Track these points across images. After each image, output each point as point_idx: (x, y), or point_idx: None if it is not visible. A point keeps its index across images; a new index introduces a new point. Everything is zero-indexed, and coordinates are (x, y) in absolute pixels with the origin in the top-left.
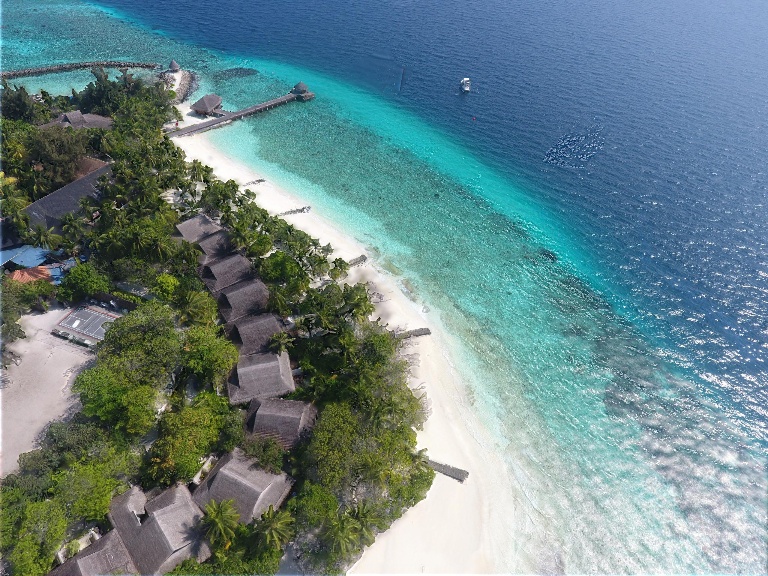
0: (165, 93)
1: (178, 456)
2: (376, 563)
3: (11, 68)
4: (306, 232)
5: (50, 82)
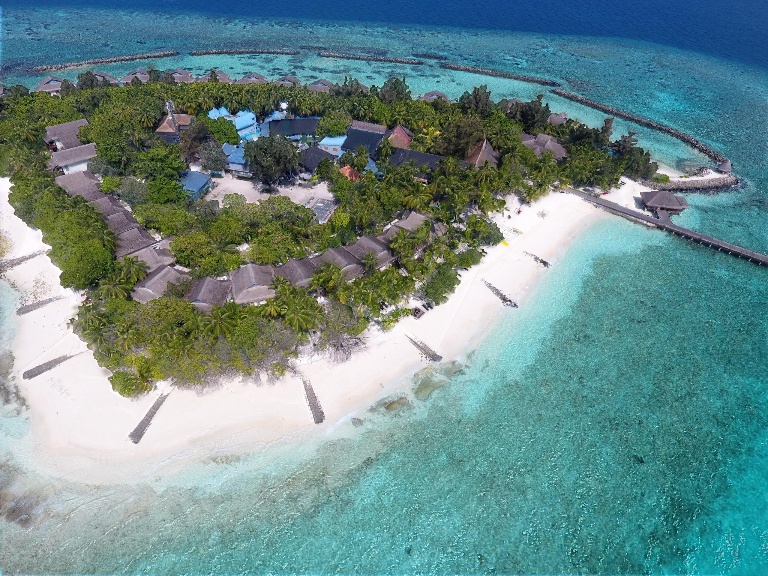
0: (651, 172)
1: (175, 241)
2: (91, 369)
3: (623, 109)
4: (464, 305)
5: (620, 127)
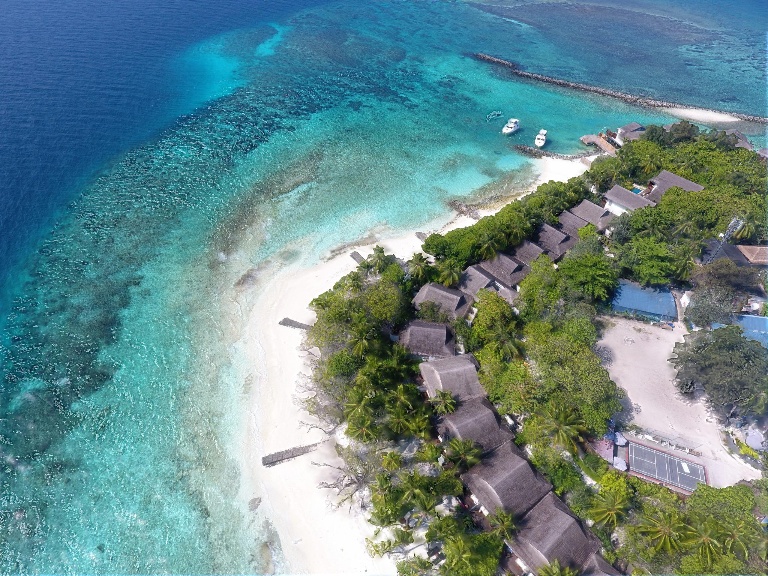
0: None
1: None
2: None
3: None
4: None
5: None
